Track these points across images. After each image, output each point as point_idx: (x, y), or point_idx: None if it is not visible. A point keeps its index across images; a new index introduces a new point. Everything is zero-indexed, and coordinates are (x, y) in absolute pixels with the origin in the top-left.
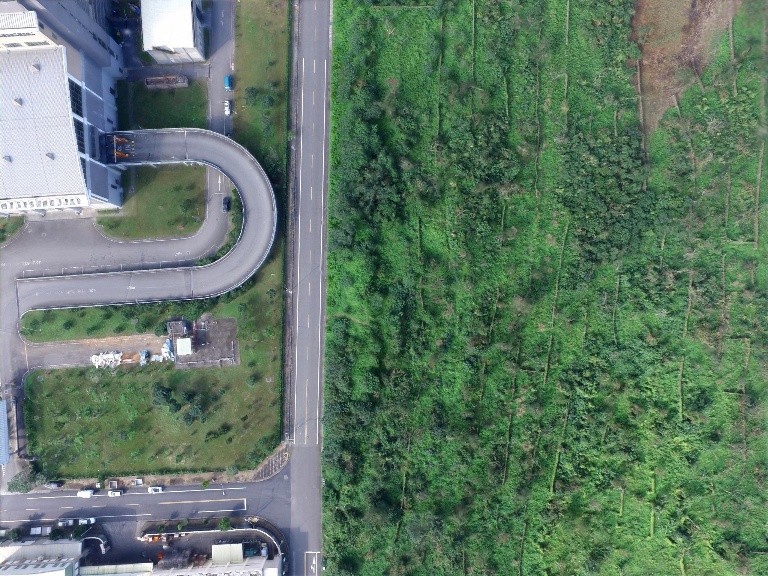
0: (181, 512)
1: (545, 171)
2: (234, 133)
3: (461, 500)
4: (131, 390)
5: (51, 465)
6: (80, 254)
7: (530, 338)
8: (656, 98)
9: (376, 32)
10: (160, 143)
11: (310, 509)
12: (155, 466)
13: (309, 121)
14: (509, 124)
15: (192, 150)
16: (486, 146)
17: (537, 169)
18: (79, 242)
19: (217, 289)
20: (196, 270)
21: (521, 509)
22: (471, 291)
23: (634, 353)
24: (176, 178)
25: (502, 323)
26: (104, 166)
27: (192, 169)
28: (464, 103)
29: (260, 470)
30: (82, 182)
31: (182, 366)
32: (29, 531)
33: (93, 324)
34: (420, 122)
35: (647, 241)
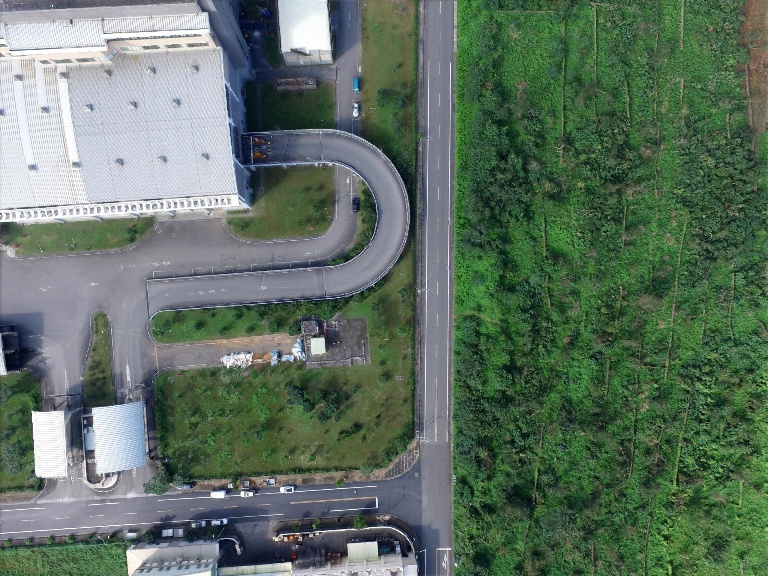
0: (313, 511)
1: (663, 172)
2: (362, 134)
3: (591, 494)
4: (263, 390)
5: (182, 466)
6: (210, 254)
7: (651, 335)
8: (763, 101)
9: (500, 36)
10: (296, 144)
11: (441, 506)
12: (287, 466)
13: (435, 123)
14: (630, 126)
15: (327, 151)
16: (611, 147)
17: (656, 170)
18: (209, 243)
19: (350, 289)
20: (328, 270)
21: (646, 502)
22: (596, 289)
23: (750, 349)
24: (305, 179)
25: (624, 320)
26: (242, 167)
27: (321, 170)
28: (587, 105)
29: (391, 468)
30: (235, 182)
31: (313, 365)
32: (161, 533)
33: (224, 324)
34: (544, 124)
35: (760, 240)
